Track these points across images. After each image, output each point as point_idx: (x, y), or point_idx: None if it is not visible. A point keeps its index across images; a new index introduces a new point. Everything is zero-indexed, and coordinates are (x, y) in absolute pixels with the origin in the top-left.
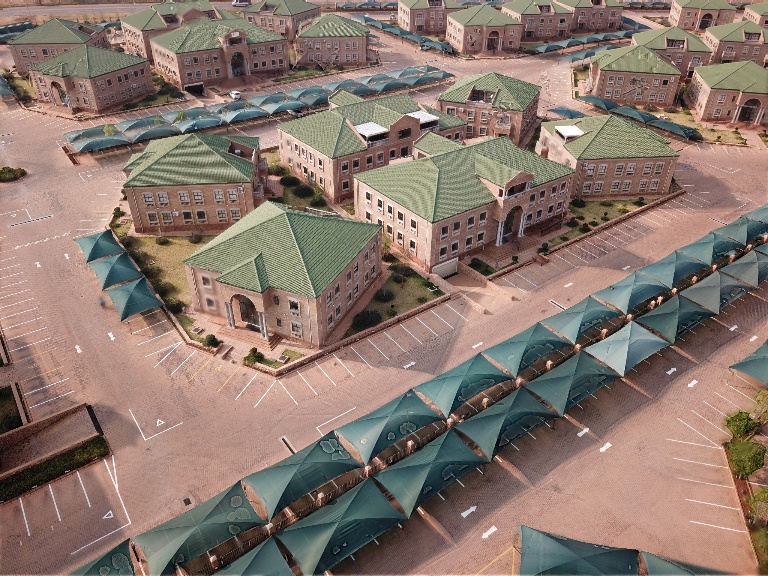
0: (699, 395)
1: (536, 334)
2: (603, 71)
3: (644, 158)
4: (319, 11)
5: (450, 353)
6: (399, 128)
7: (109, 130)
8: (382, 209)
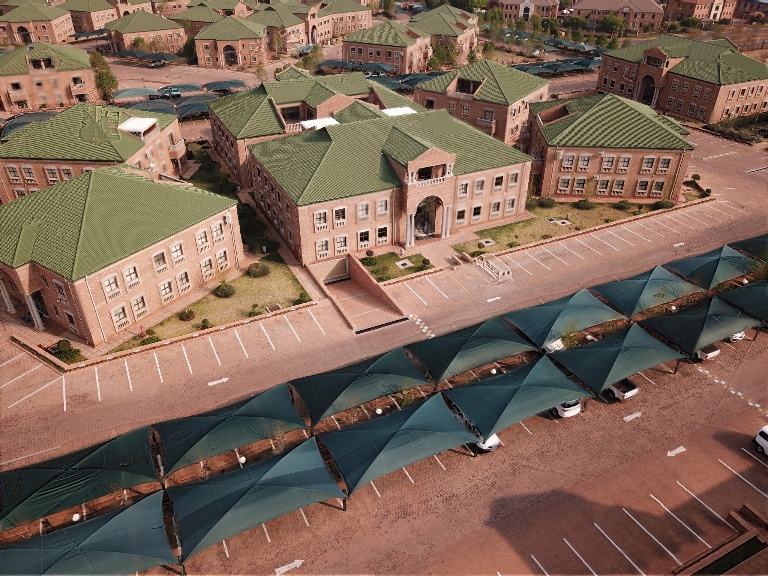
0: None
1: None
2: None
3: None
4: None
5: None
6: None
7: None
8: None
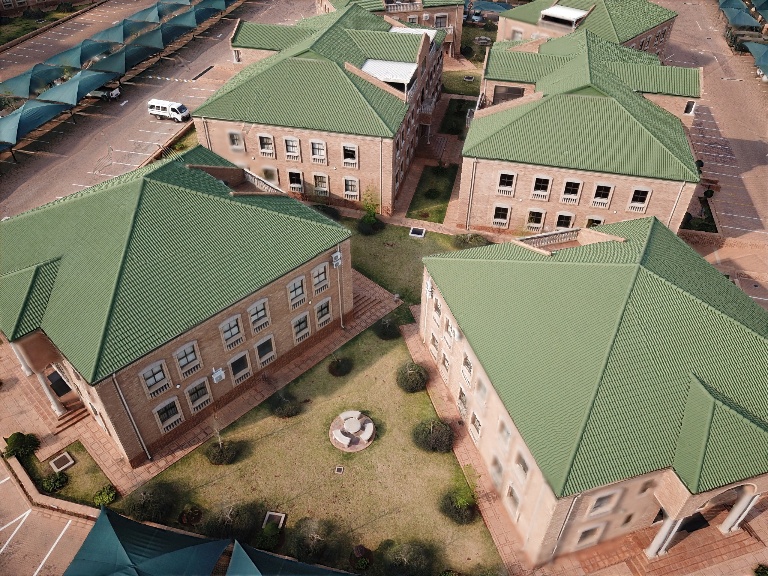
0: None
1: None
2: None
3: (657, 26)
4: None
5: None
6: (421, 58)
7: None
8: (548, 193)
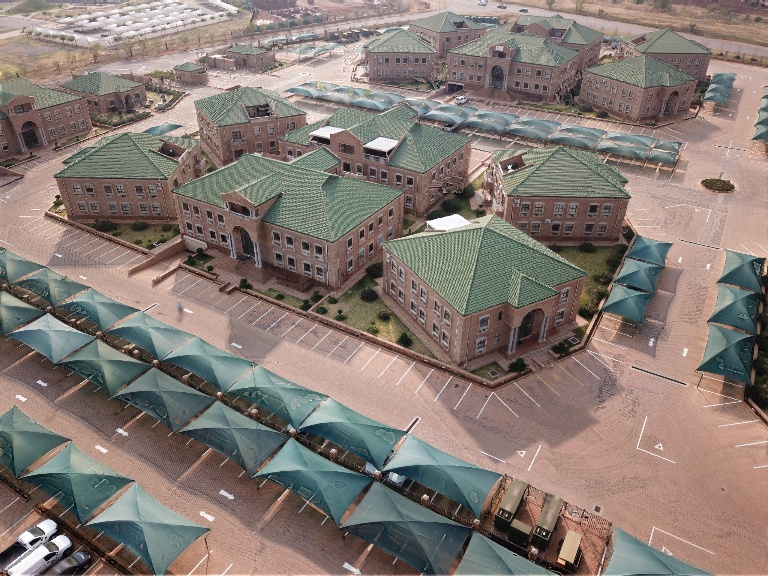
0: (2, 402)
1: (59, 282)
2: None
3: None
4: (708, 58)
5: (72, 268)
6: (340, 141)
7: (321, 86)
8: None
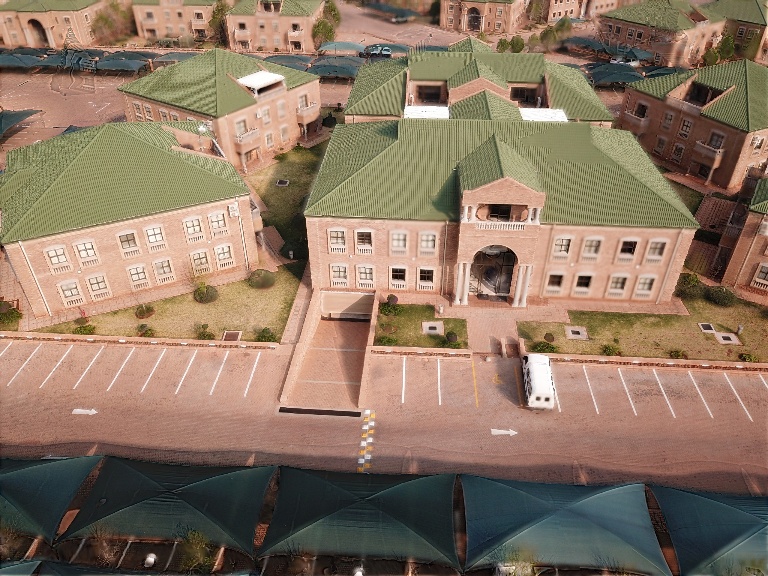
0: None
1: None
2: None
3: None
4: None
5: None
6: None
7: None
8: None
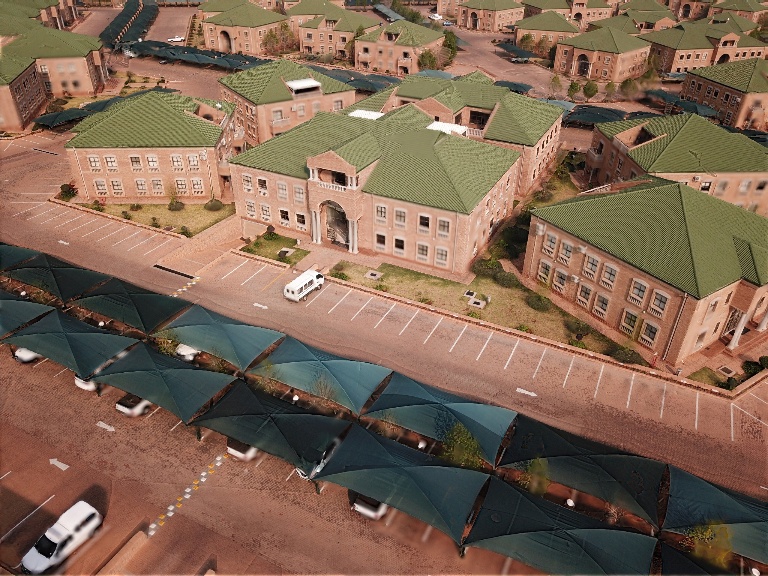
0: None
1: None
2: (9, 85)
3: None
4: None
5: None
6: None
7: None
8: None
